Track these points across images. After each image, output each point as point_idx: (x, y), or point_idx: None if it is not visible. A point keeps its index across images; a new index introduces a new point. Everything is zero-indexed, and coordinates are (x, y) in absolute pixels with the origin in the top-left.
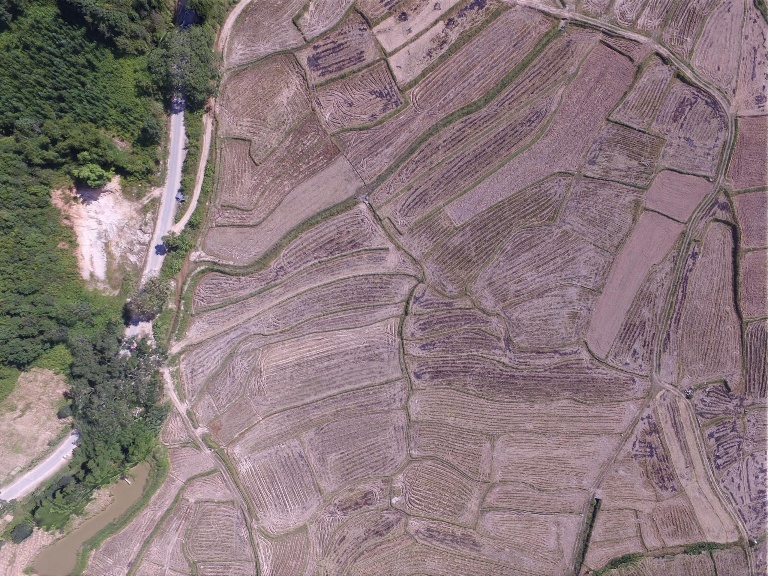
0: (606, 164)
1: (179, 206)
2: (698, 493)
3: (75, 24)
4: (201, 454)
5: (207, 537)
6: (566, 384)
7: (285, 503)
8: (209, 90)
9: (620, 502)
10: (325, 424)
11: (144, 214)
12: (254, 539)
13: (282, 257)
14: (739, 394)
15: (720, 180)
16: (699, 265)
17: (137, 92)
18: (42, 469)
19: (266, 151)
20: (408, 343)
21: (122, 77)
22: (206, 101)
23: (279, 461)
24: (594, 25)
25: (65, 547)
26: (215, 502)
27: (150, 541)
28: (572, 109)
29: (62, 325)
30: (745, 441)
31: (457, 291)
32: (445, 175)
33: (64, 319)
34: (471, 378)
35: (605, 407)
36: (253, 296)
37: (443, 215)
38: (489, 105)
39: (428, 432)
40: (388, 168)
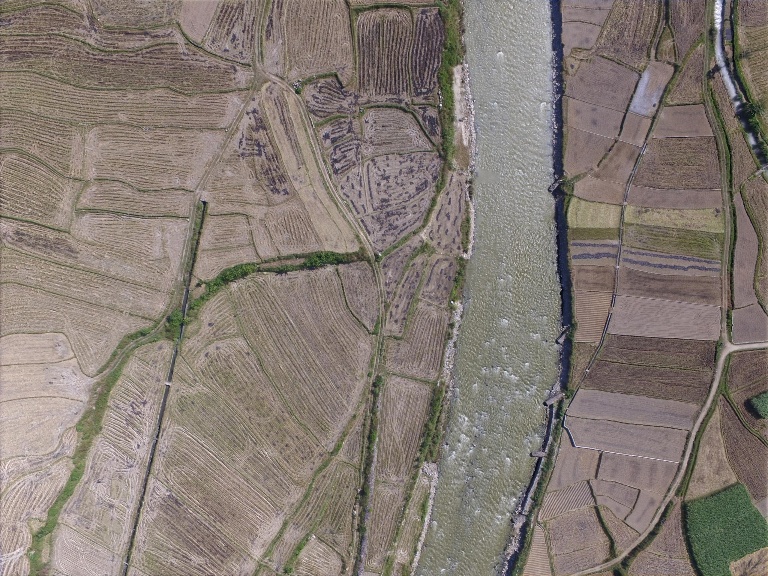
0: None
1: None
2: (313, 197)
3: None
4: None
5: None
6: (161, 71)
7: None
8: None
9: (229, 206)
10: None
11: None
12: None
13: None
14: (353, 91)
15: None
16: None
17: None
18: None
19: None
20: None
21: None
22: None
23: None
24: None
25: None
26: None
27: None
28: None
29: None
30: (364, 144)
31: None
32: None
33: None
34: (54, 61)
35: (206, 99)
36: None
37: None
38: None
39: (10, 121)
40: None
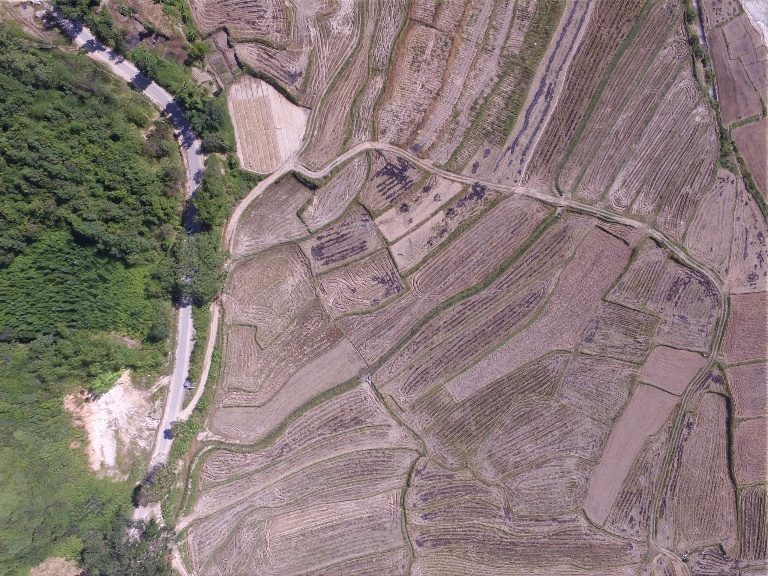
0: (602, 341)
1: (187, 394)
2: None
3: (88, 247)
4: None
5: None
6: (565, 550)
7: None
8: (216, 287)
9: None
10: None
11: (153, 402)
12: None
13: (287, 434)
14: (734, 557)
15: (714, 355)
16: (694, 434)
17: (147, 295)
18: None
19: (271, 336)
20: (410, 513)
21: (132, 284)
22: (213, 295)
23: None
24: (590, 212)
25: None
26: None
27: None
28: (569, 290)
29: (74, 521)
30: None
31: (458, 464)
32: (446, 354)
33: (76, 516)
34: (472, 545)
35: (603, 571)
36: (259, 472)
37: (444, 392)
38: (488, 288)
39: None
40: (390, 349)
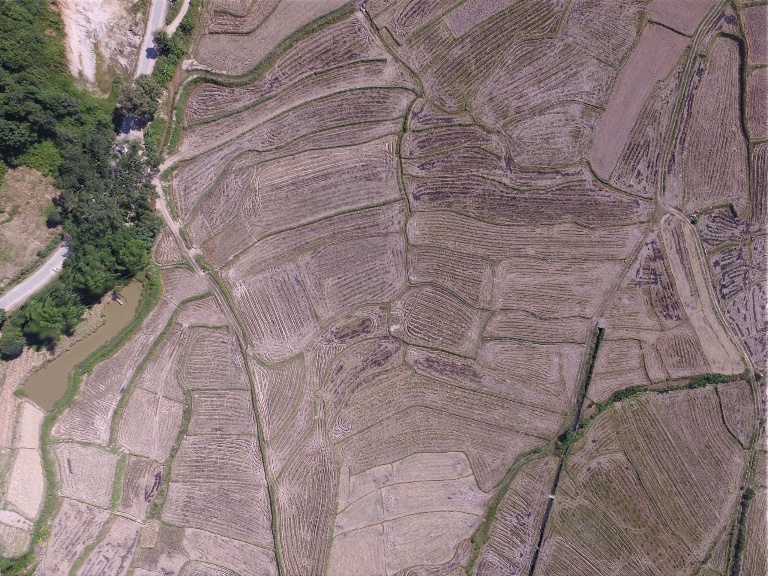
0: None
1: (170, 6)
2: (703, 322)
3: None
4: (195, 276)
5: (201, 364)
6: (568, 207)
7: (281, 330)
8: None
9: (623, 332)
10: (322, 247)
11: (134, 13)
12: (249, 366)
13: (277, 68)
14: (745, 220)
15: None
16: (705, 83)
17: None
18: (31, 282)
19: None
20: (406, 162)
21: None
22: None
23: (275, 285)
24: None
25: (56, 370)
26: (209, 327)
27: (143, 367)
28: None
29: (50, 116)
30: (751, 270)
31: (457, 106)
32: None
33: (52, 109)
34: (471, 200)
35: (608, 231)
36: (247, 109)
37: (442, 25)
38: None
39: (427, 257)
40: None
